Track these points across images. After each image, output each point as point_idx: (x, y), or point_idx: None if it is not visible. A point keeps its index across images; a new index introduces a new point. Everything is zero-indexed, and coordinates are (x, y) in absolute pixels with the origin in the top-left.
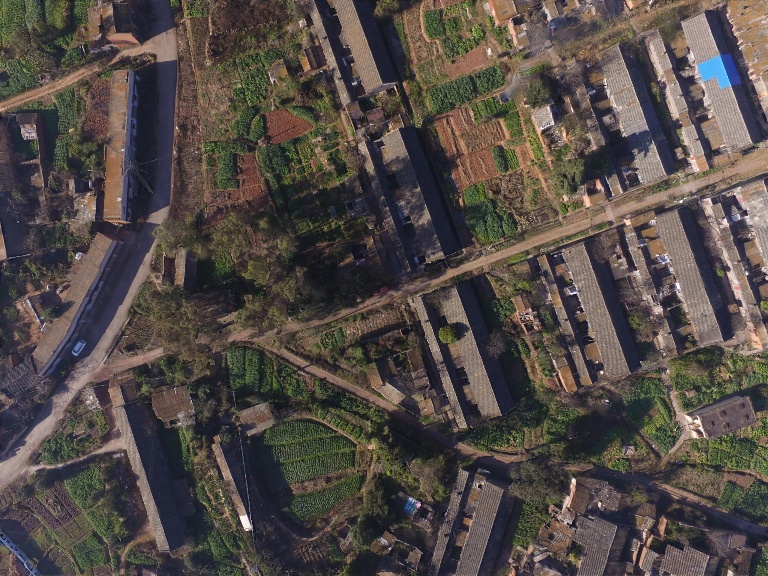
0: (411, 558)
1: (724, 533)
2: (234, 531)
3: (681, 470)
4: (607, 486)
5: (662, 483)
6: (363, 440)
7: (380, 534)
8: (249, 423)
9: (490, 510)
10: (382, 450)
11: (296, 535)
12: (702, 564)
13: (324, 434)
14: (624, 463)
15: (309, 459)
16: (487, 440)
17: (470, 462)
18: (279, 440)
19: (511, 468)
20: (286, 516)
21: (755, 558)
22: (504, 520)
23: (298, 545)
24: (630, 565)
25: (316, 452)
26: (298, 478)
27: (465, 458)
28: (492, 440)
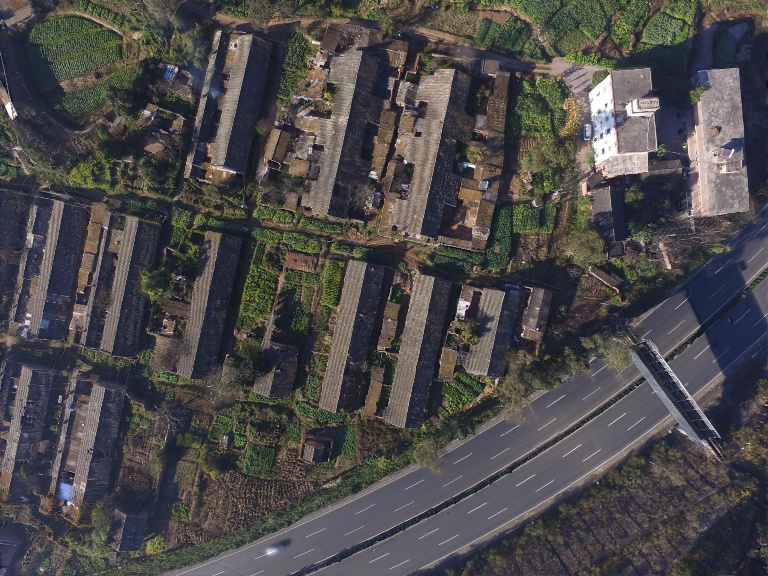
0: (175, 126)
1: (476, 58)
2: (2, 122)
3: (435, 12)
4: (359, 28)
5: (418, 27)
6: (126, 27)
7: (143, 107)
8: (5, 9)
9: (242, 60)
10: (135, 17)
11: (68, 129)
12: (450, 80)
13: (89, 28)
14: (378, 11)
15: (77, 56)
16: (244, 7)
17: (229, 31)
18: (45, 38)
19: (270, 33)
20: (59, 115)
21: (515, 89)
22: (260, 73)
23: (70, 138)
24: (387, 102)
25: (83, 48)
26: (68, 76)
27: (224, 28)
28: (248, 6)
